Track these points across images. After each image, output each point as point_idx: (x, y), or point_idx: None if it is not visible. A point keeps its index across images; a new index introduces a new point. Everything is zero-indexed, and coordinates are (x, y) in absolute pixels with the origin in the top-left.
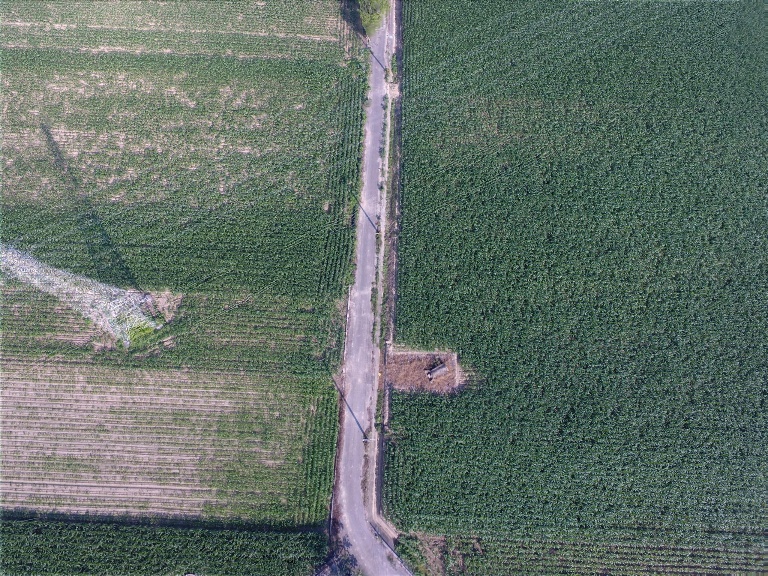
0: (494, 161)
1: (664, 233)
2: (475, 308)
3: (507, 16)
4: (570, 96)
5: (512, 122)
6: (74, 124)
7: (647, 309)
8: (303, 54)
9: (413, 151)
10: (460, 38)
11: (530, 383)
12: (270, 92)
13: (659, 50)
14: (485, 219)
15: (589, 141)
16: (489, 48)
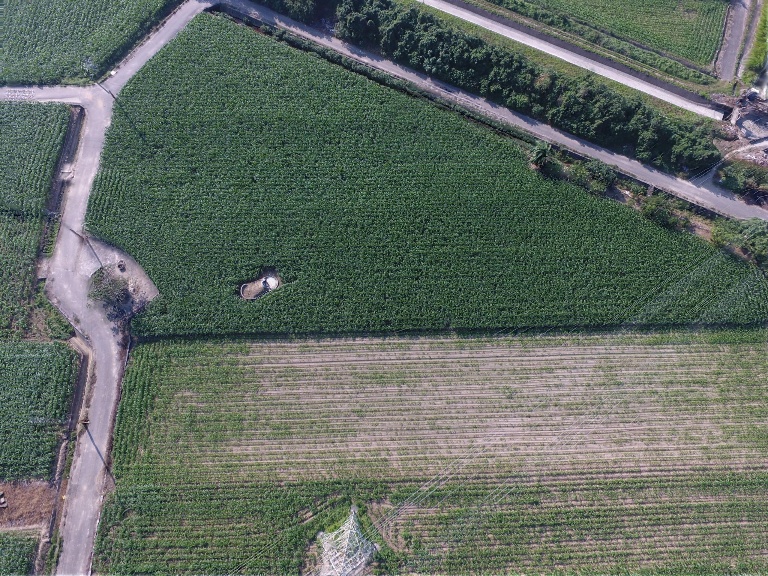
0: None
1: None
2: None
3: None
4: None
5: None
6: None
7: None
8: None
9: None
10: None
11: None
12: None
13: None
14: None
15: None
16: None
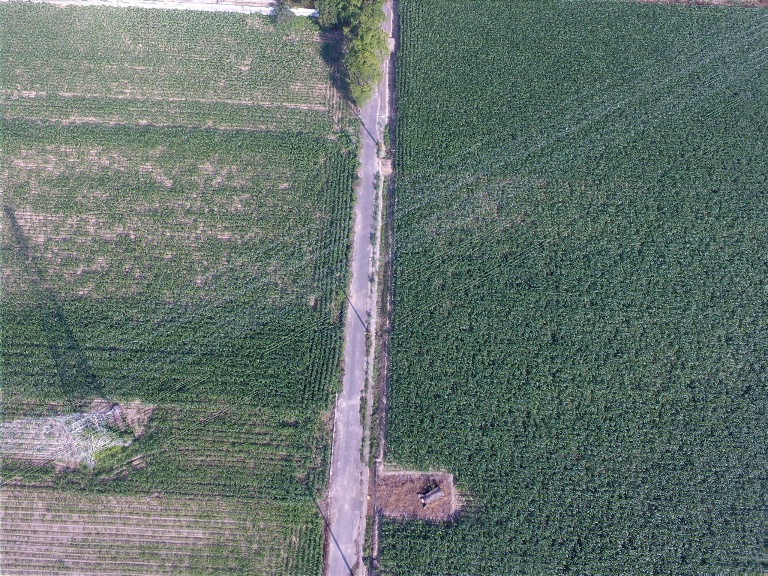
0: (494, 249)
1: (677, 332)
2: (473, 422)
3: (507, 83)
4: (575, 174)
5: (513, 204)
6: (40, 206)
7: (660, 422)
8: (289, 126)
9: (406, 238)
10: (457, 108)
11: (533, 511)
12: (253, 169)
13: (670, 122)
14: (484, 317)
15: (596, 226)
16: (488, 120)
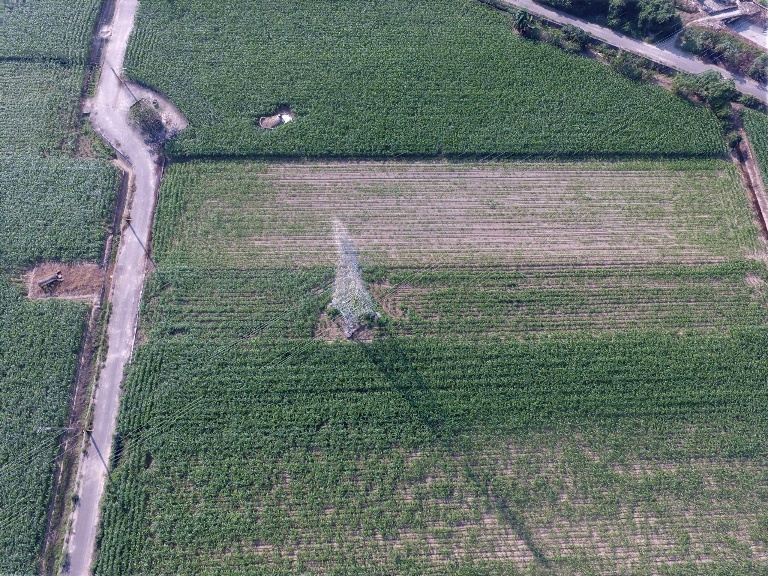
0: None
1: None
2: None
3: None
4: None
5: None
6: (505, 571)
7: None
8: None
9: (17, 568)
10: None
11: None
12: None
13: None
14: None
15: None
16: None
